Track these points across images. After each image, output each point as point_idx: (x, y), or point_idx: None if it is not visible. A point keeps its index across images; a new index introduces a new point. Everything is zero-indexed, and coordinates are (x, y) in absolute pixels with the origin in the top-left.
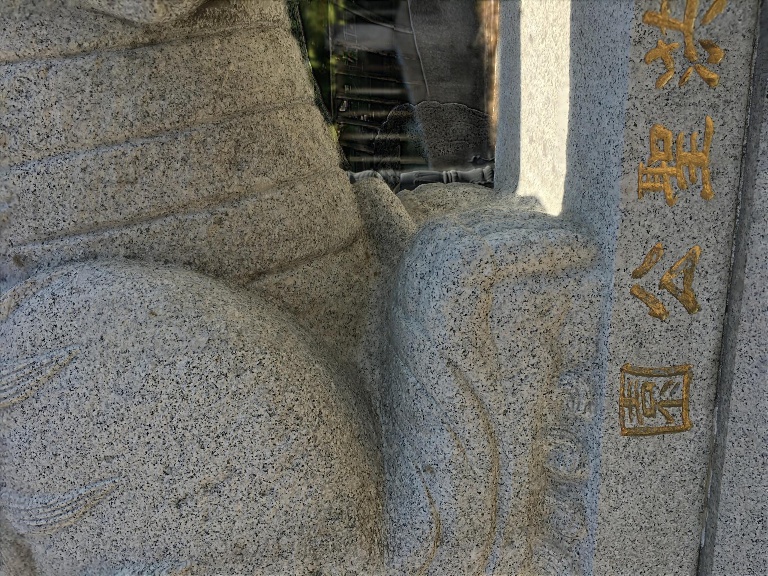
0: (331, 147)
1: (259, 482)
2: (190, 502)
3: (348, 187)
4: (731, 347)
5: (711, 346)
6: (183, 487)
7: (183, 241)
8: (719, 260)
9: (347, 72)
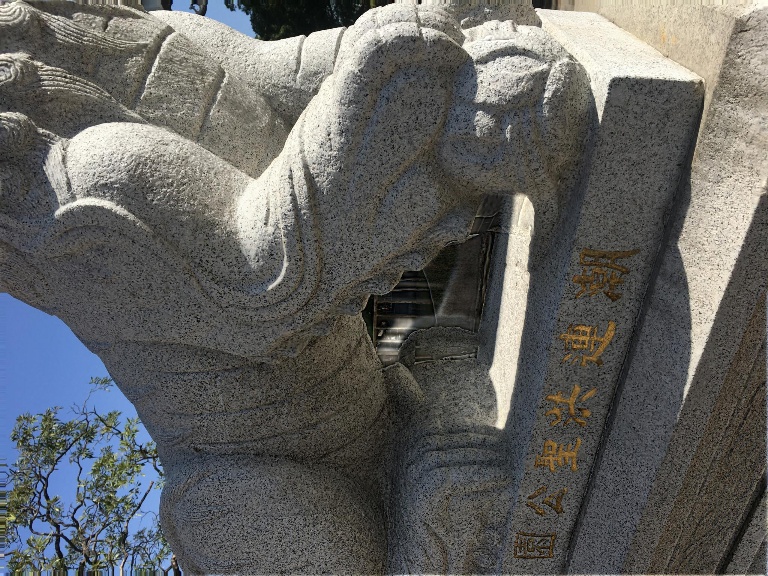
0: (371, 363)
1: (322, 568)
2: (287, 573)
3: (380, 378)
4: (578, 531)
5: (568, 527)
6: (284, 567)
7: (285, 447)
8: (577, 494)
9: (384, 315)
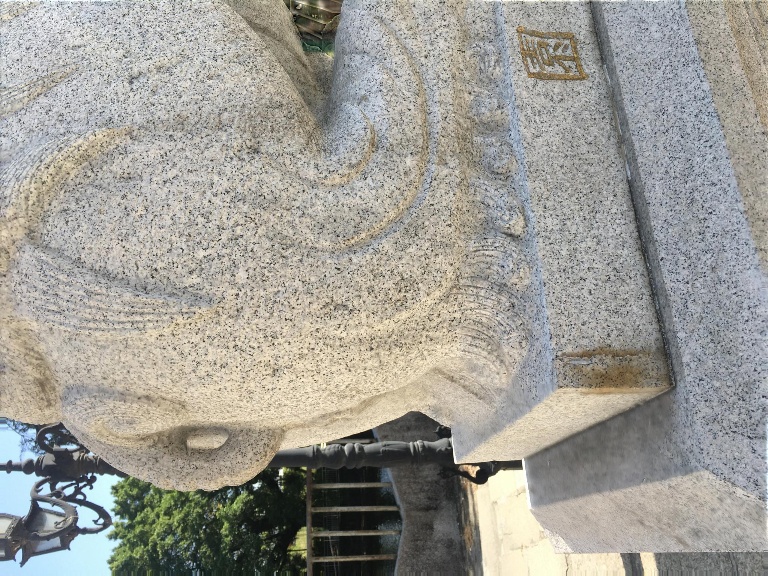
0: None
1: (208, 68)
2: (142, 79)
3: None
4: (600, 15)
5: (586, 22)
6: (138, 67)
7: None
8: None
9: None
